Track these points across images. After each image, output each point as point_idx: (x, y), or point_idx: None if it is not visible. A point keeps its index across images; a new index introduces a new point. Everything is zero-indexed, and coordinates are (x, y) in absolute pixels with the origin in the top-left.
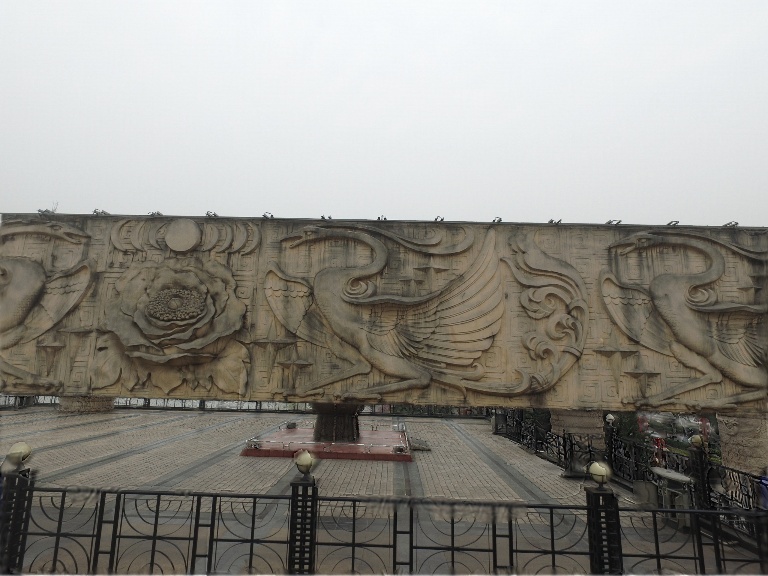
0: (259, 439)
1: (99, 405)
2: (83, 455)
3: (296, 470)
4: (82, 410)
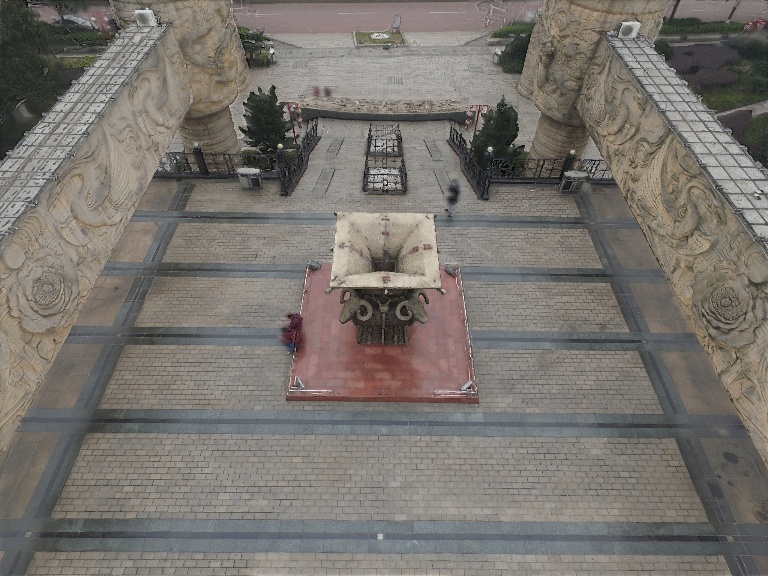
0: (365, 414)
1: None
2: None
3: None
4: None
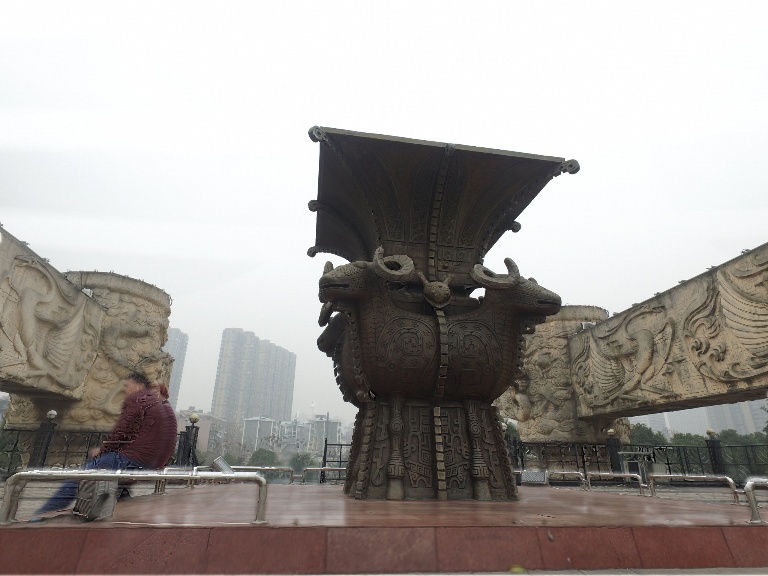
0: None
1: None
2: None
3: None
4: None
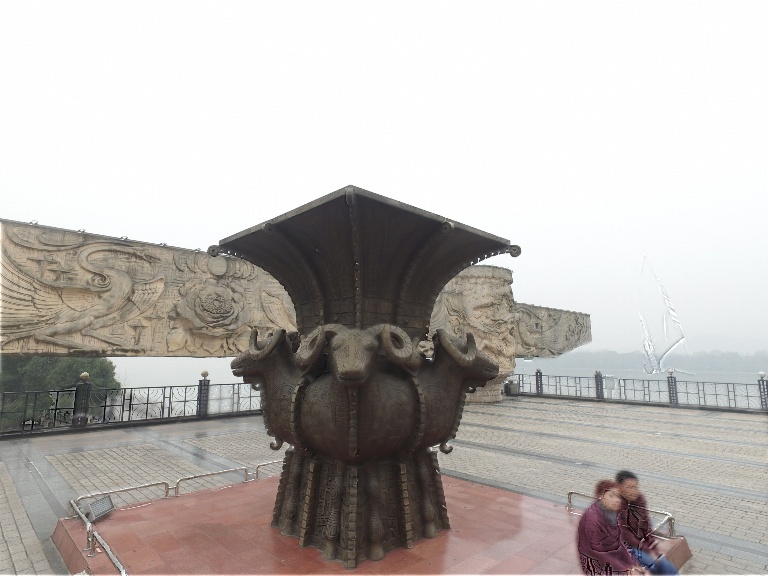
0: None
1: None
2: (471, 436)
3: None
4: None
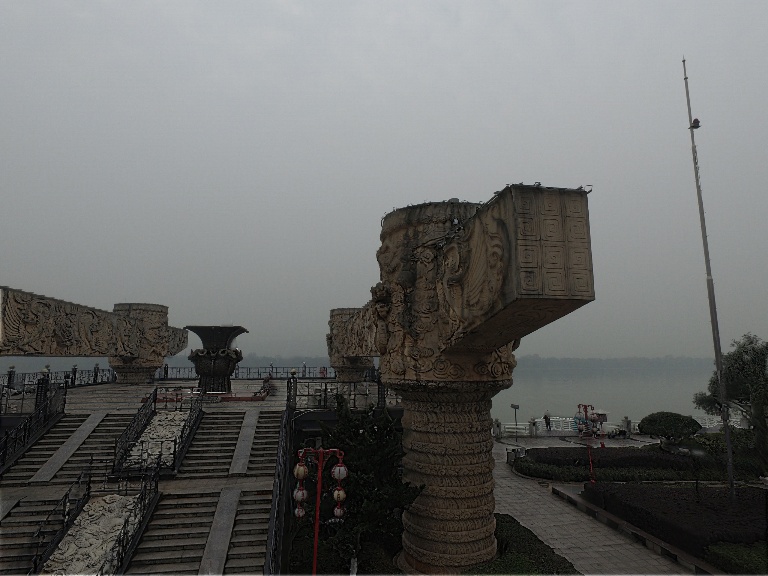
0: None
1: (345, 377)
2: None
3: None
4: (338, 380)
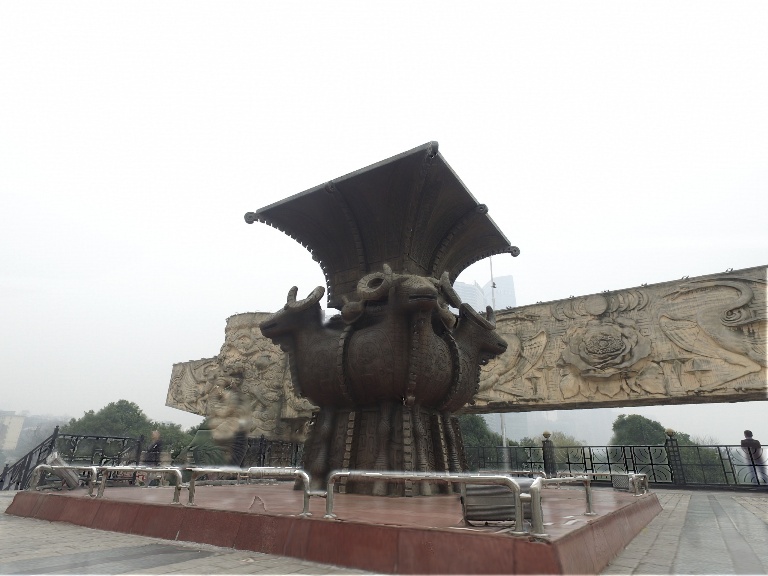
0: None
1: None
2: None
3: (549, 438)
4: None
